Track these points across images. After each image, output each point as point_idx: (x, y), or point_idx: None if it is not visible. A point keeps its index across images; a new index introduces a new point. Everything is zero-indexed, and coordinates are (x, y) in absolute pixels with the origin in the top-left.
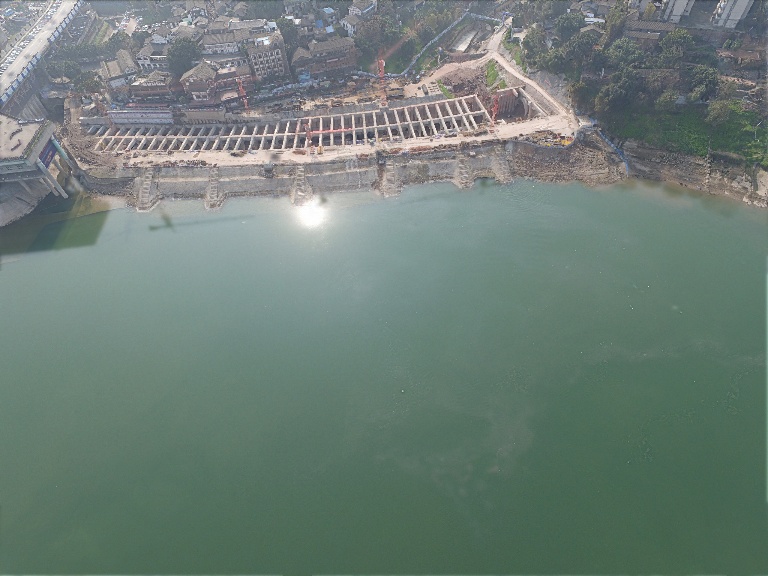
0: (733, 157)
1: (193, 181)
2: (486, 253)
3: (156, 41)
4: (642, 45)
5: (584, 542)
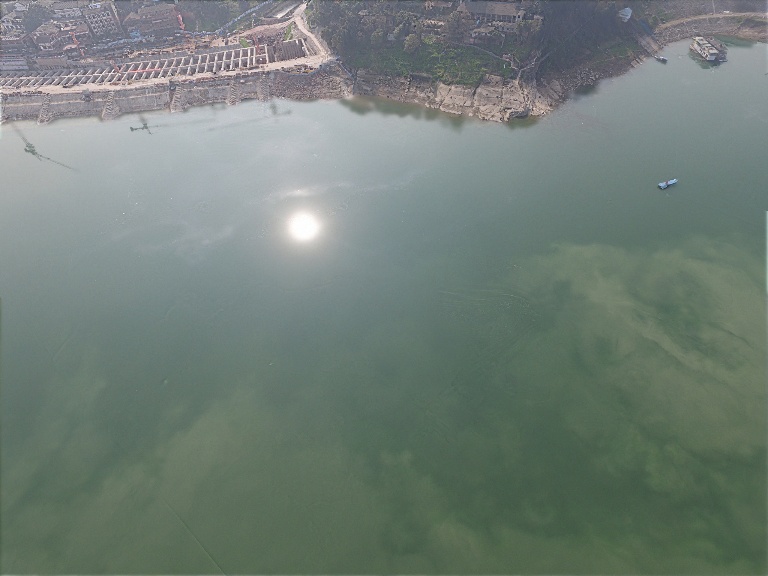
0: (424, 76)
1: (30, 105)
2: (226, 142)
3: (19, 9)
4: (373, 0)
5: (195, 275)
